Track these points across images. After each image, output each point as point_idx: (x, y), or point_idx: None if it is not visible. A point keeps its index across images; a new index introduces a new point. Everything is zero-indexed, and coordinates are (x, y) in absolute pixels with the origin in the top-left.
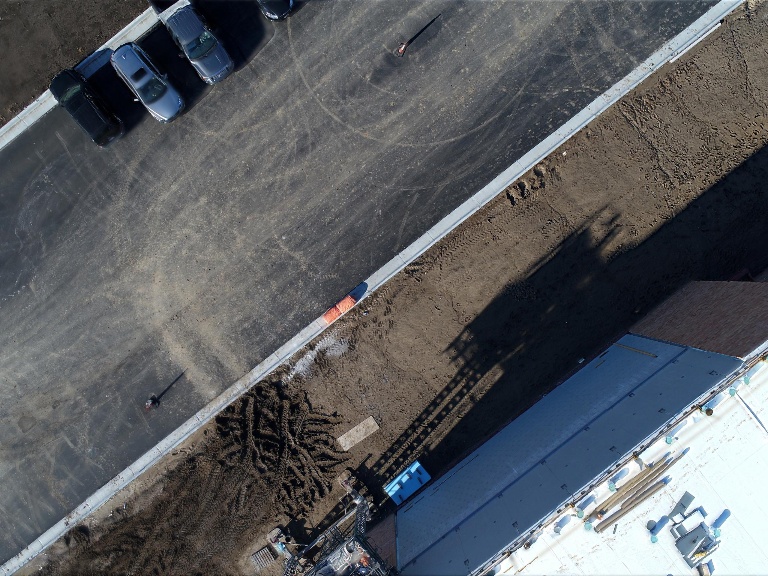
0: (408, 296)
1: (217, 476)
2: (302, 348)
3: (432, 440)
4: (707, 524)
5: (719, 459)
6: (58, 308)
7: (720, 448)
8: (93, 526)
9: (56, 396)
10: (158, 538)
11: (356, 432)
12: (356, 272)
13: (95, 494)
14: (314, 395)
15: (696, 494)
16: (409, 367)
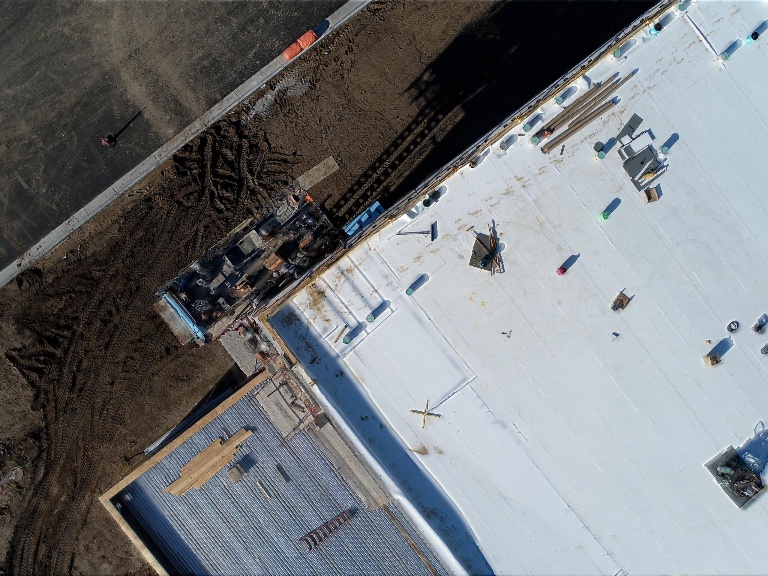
0: (370, 35)
1: (174, 217)
2: (262, 87)
3: (393, 181)
4: (655, 148)
5: (668, 82)
6: (13, 43)
7: (669, 70)
8: (46, 269)
9: (10, 135)
10: (113, 280)
11: (316, 172)
12: (318, 10)
13: (49, 235)
14: (274, 135)
15: (644, 116)
16: (370, 107)
